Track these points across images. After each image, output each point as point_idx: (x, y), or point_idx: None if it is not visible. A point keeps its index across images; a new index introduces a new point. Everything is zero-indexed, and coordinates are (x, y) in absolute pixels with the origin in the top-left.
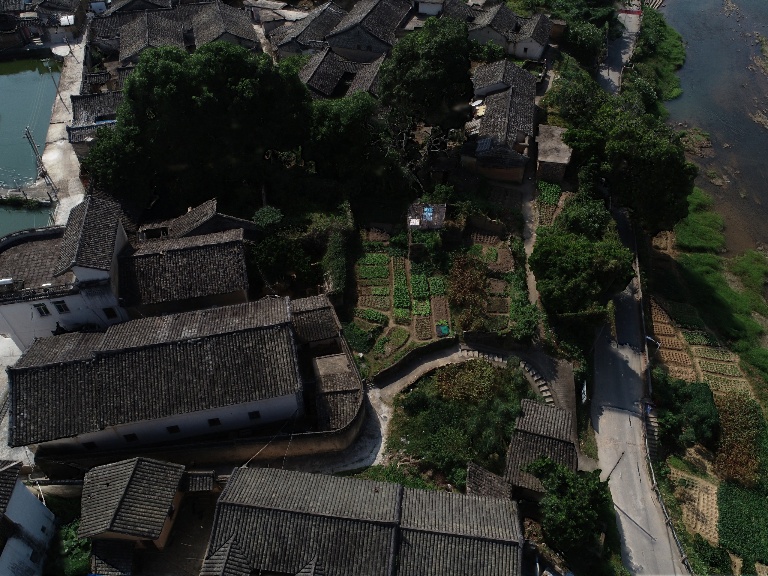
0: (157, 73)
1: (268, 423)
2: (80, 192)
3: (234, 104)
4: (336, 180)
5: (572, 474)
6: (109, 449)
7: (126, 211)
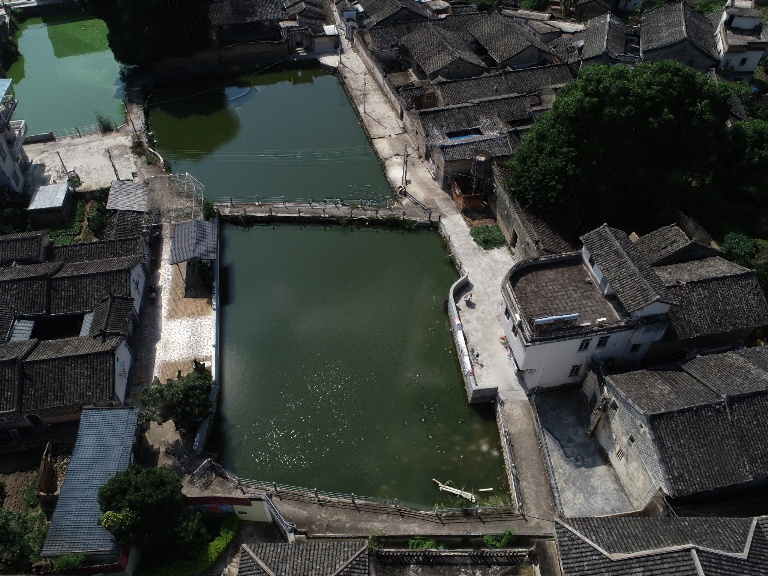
0: (614, 94)
1: None
2: (455, 212)
3: (693, 126)
4: (752, 203)
5: None
6: (709, 496)
7: (561, 235)
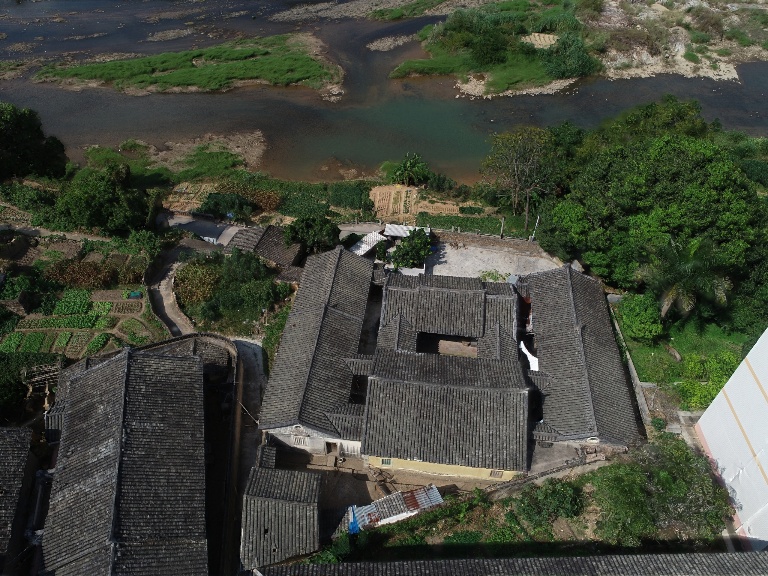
0: None
1: None
2: None
3: None
4: None
5: None
6: None
7: None
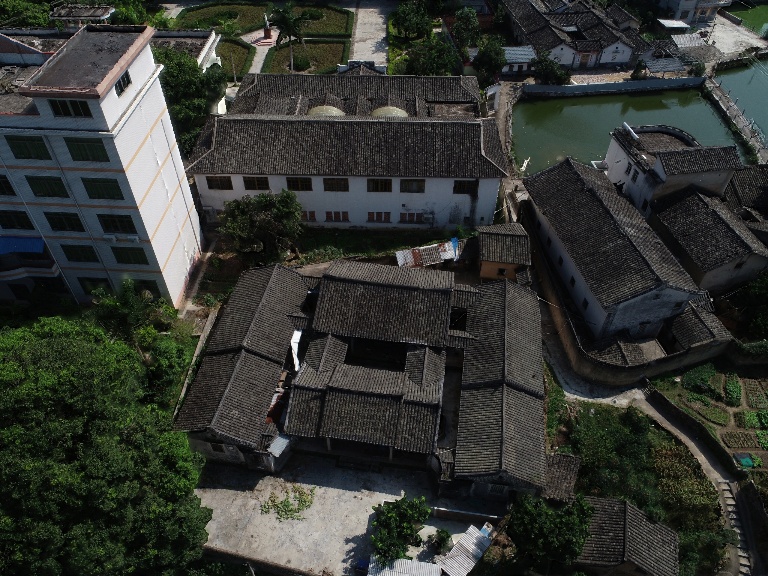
0: None
1: (585, 321)
2: None
3: None
4: None
5: None
6: (540, 237)
7: (763, 194)
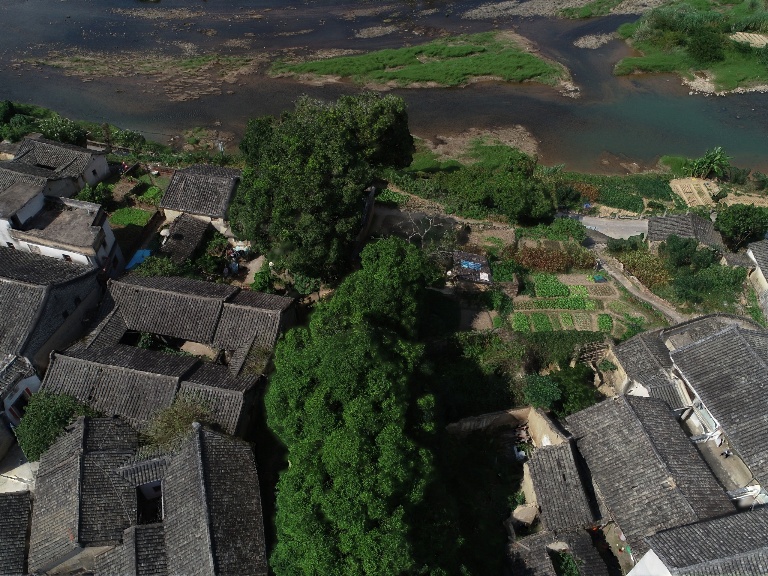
0: None
1: None
2: None
3: None
4: None
5: (730, 208)
6: None
7: None
